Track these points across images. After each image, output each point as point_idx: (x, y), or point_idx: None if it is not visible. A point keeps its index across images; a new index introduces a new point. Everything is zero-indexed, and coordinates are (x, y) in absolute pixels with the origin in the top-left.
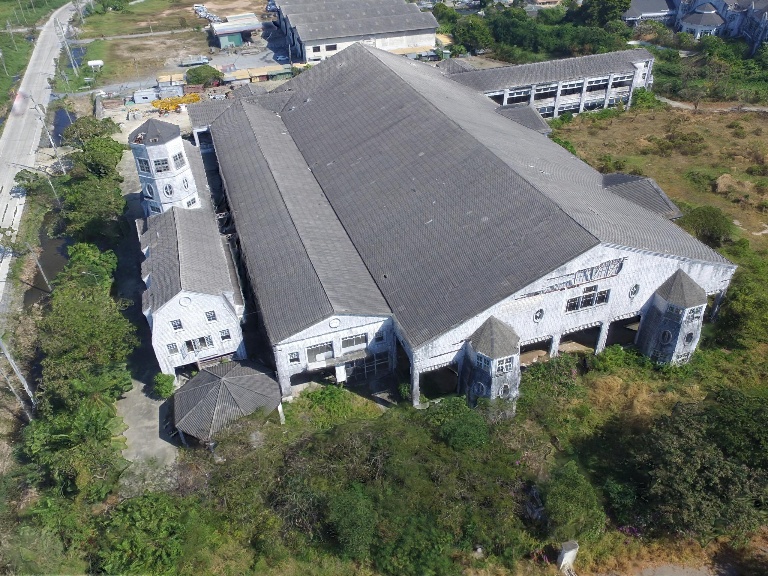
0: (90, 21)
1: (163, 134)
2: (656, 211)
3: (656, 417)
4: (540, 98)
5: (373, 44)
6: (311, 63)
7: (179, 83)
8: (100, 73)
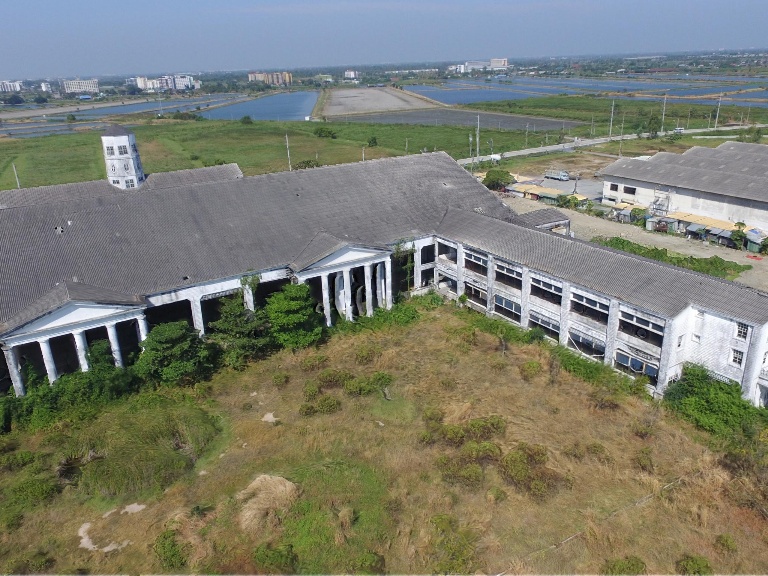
0: (618, 141)
1: None
2: (12, 318)
3: None
4: (505, 282)
5: (667, 198)
6: (606, 202)
7: (479, 179)
8: (496, 166)
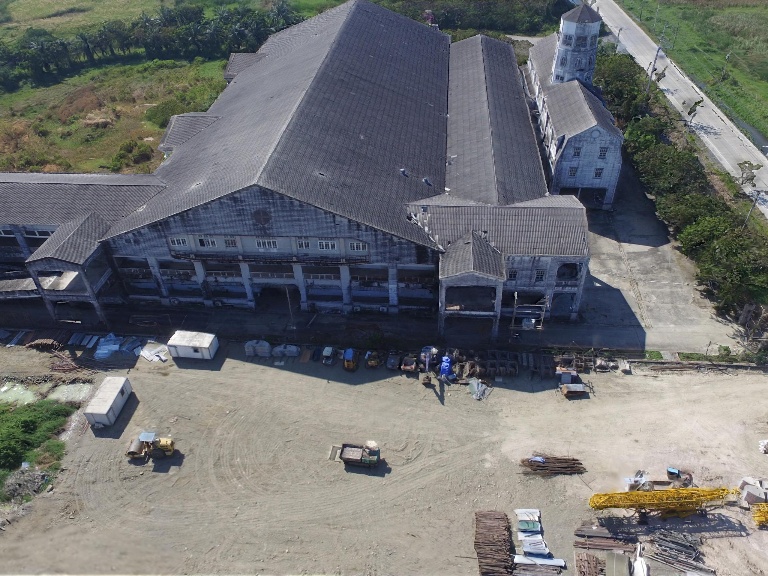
0: None
1: None
2: None
3: None
4: None
5: None
6: None
7: None
8: None
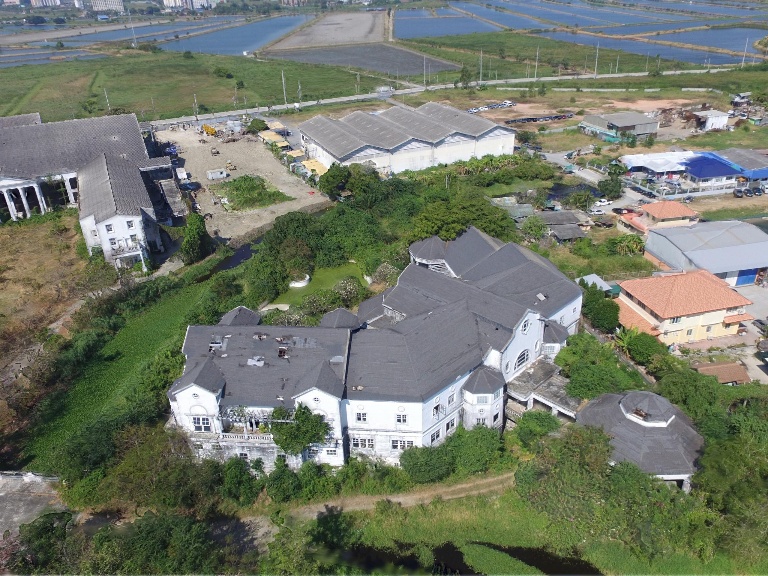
0: None
1: None
2: None
3: None
4: None
5: None
6: None
7: None
8: (297, 112)
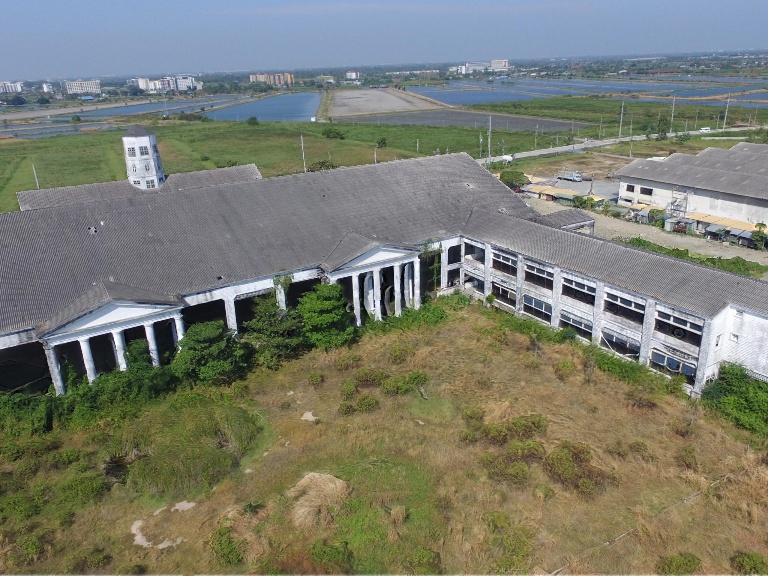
0: None
1: (128, 132)
2: (53, 318)
3: None
4: (535, 282)
5: (685, 199)
6: (622, 202)
7: None
8: (507, 167)
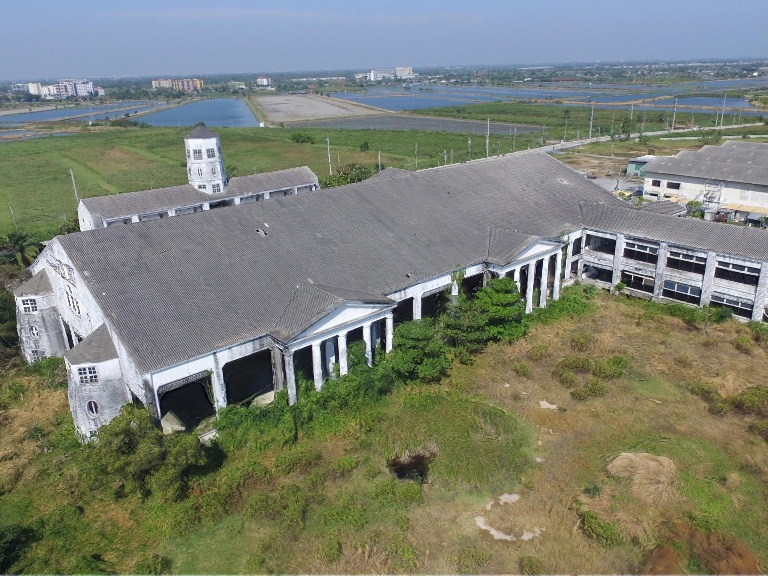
0: None
1: (193, 134)
2: (282, 323)
3: (3, 432)
4: (679, 267)
5: (718, 191)
6: (647, 197)
7: None
8: None
